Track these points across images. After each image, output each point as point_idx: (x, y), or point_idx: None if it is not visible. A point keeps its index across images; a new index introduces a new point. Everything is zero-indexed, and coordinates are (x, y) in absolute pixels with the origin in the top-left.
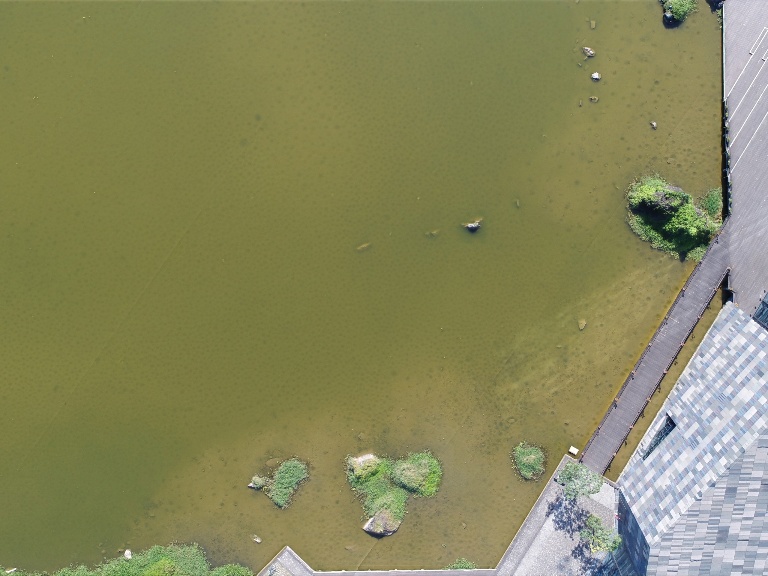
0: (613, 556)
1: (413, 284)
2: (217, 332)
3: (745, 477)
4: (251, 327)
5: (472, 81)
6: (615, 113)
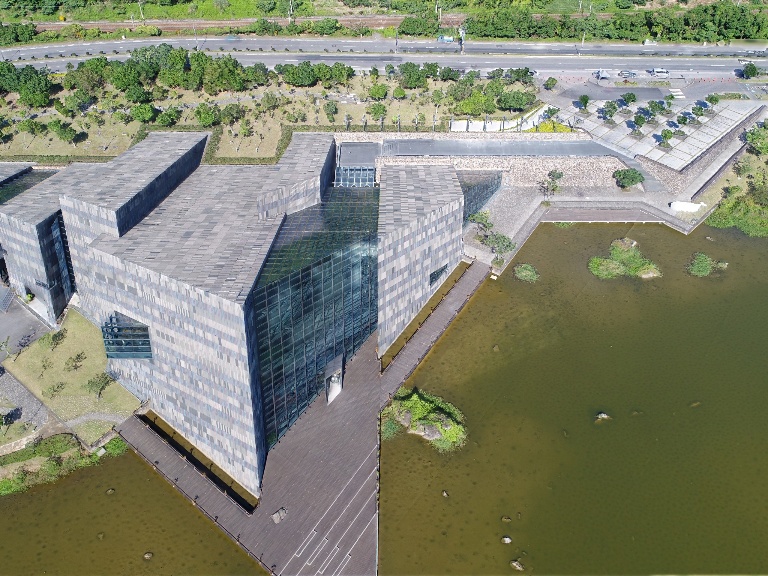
0: None
1: (644, 378)
2: None
3: None
4: None
5: (634, 541)
6: (484, 506)
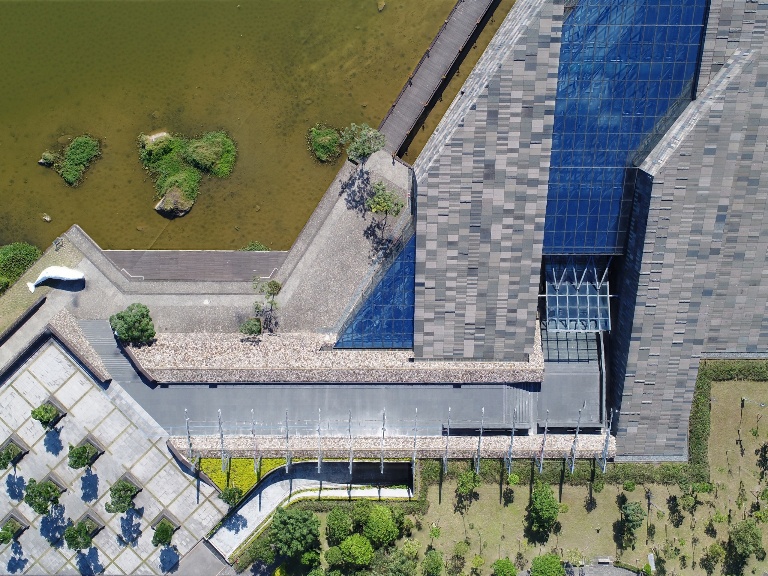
0: (403, 232)
1: None
2: (11, 5)
3: (505, 98)
4: (46, 1)
5: None
6: None
